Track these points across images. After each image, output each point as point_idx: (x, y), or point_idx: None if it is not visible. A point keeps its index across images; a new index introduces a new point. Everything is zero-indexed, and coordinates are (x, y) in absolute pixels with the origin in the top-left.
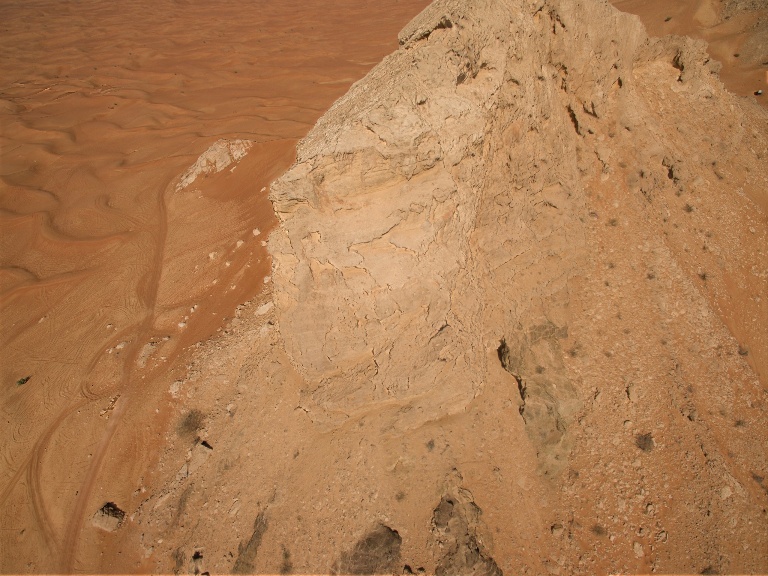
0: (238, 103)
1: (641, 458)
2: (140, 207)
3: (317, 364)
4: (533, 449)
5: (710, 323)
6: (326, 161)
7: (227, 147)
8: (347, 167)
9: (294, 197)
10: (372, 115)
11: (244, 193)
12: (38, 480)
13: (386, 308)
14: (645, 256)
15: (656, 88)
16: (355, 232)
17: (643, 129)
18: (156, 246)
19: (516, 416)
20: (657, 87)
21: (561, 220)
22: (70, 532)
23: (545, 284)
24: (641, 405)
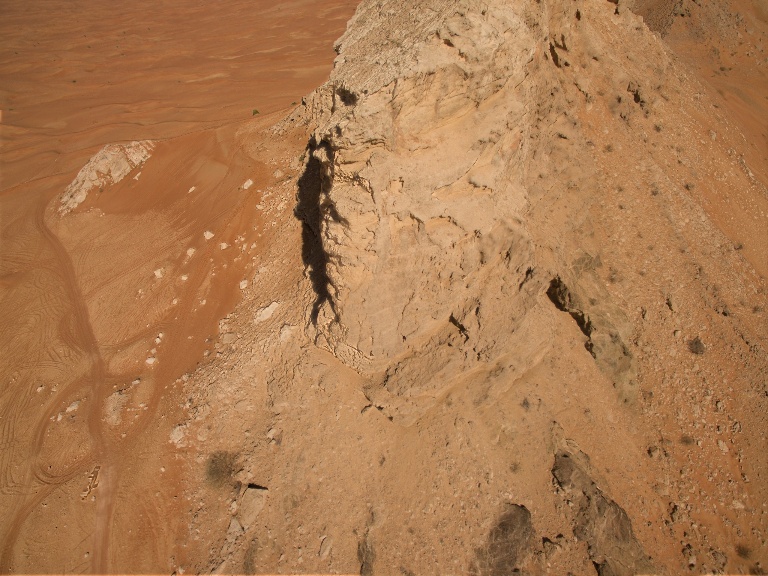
0: (95, 113)
1: (697, 362)
2: (16, 243)
3: (390, 348)
4: (608, 381)
5: (709, 226)
6: (406, 86)
7: (121, 152)
8: (424, 94)
9: (371, 137)
10: (450, 24)
11: (165, 199)
12: None
13: (473, 260)
14: (644, 175)
15: (602, 21)
16: (439, 173)
17: (607, 58)
18: (64, 282)
19: (584, 353)
20: (602, 20)
21: (574, 150)
22: None
23: (573, 217)
24: (682, 313)
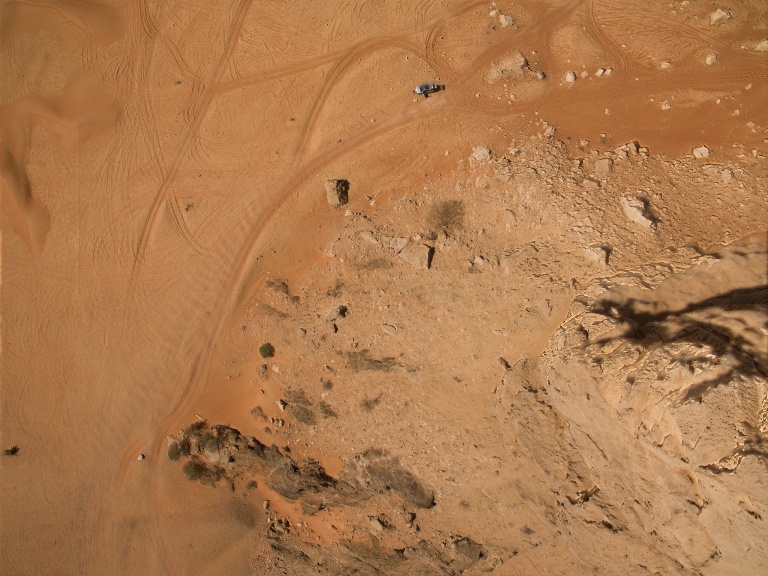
0: None
1: None
2: None
3: None
4: None
5: None
6: None
7: None
8: None
9: None
10: None
11: None
12: (333, 85)
13: None
14: None
15: None
16: None
17: None
18: None
19: None
20: None
21: None
22: (312, 165)
23: None
24: None
